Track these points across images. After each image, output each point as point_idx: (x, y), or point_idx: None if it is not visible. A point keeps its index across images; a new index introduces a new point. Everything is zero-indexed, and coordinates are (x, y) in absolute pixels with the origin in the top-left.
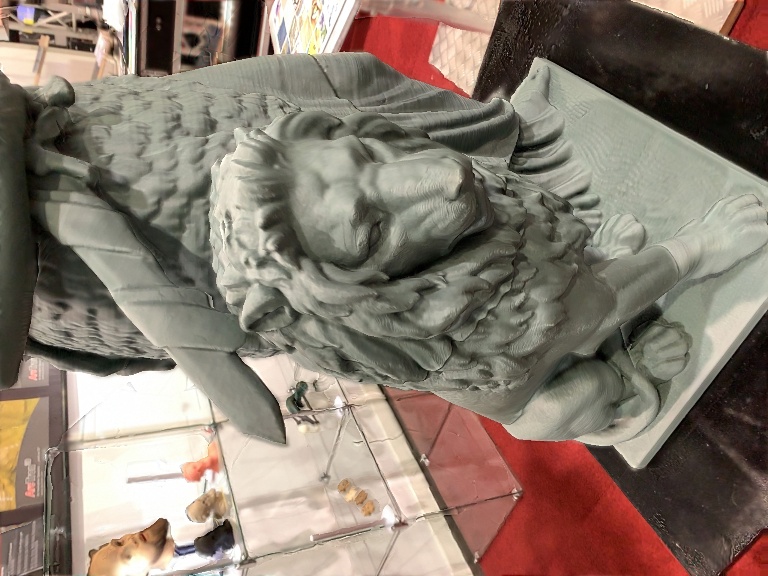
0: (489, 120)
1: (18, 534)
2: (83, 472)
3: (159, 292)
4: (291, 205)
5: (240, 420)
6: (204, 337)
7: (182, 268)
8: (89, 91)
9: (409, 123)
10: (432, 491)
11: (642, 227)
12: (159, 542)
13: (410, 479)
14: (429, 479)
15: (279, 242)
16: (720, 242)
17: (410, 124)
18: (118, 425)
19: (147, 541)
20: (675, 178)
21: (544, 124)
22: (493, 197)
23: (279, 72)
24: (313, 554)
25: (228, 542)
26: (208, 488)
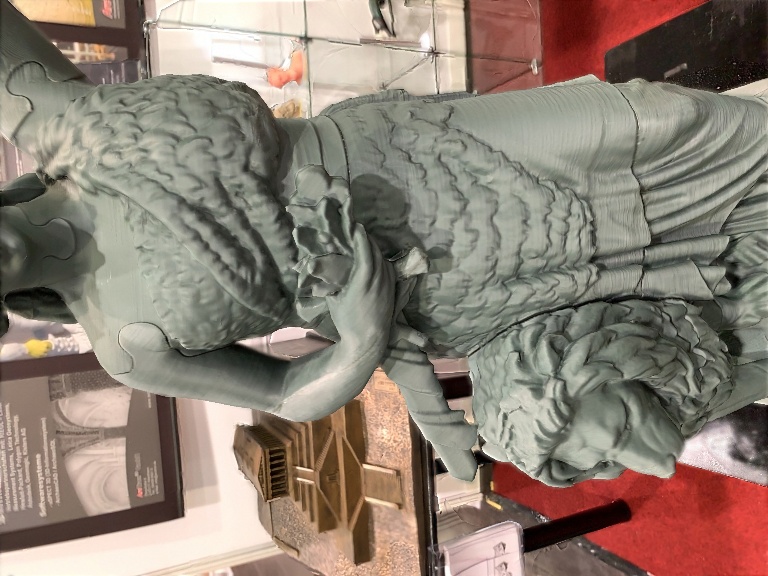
0: (750, 175)
1: (109, 71)
2: (156, 2)
3: (439, 417)
4: (557, 448)
5: (455, 475)
6: (455, 443)
7: (446, 354)
8: (427, 205)
9: (676, 204)
10: None
11: None
12: None
13: None
14: None
15: (538, 472)
16: None
17: (676, 205)
18: (215, 15)
19: None
20: None
21: None
22: (684, 405)
23: (596, 151)
24: None
25: None
26: (275, 61)
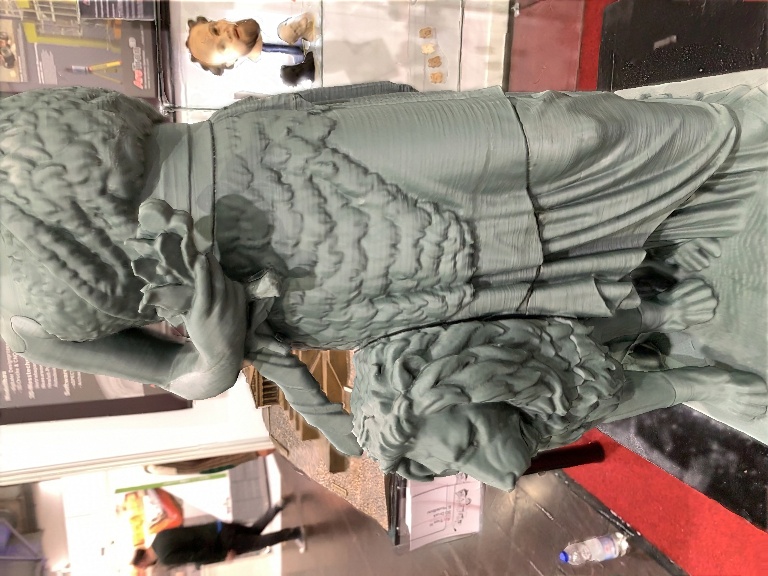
0: (677, 192)
1: None
2: None
3: (315, 408)
4: (406, 454)
5: None
6: (334, 428)
7: None
8: (291, 228)
9: (579, 223)
10: (507, 39)
11: (711, 318)
12: (250, 44)
13: (493, 17)
14: (510, 25)
15: None
16: (718, 403)
17: (579, 225)
18: None
19: (240, 38)
20: (764, 324)
21: (754, 158)
22: (551, 421)
23: (479, 177)
24: (377, 64)
25: (309, 78)
26: None
